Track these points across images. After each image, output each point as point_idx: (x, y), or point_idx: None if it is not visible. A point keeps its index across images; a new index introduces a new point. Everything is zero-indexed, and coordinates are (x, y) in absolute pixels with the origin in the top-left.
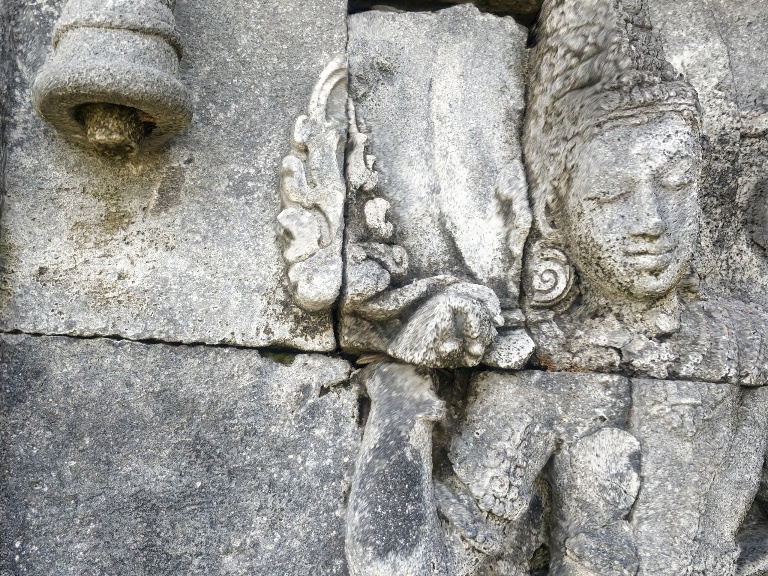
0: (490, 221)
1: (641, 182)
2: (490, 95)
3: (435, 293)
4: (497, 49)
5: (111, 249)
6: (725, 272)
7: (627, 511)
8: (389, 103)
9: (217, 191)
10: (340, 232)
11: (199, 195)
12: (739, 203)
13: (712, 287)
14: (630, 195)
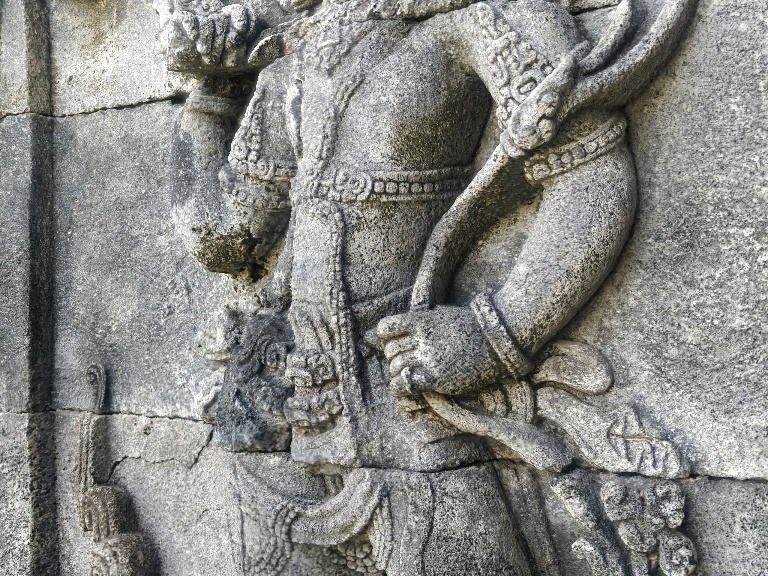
0: None
1: None
2: None
3: None
4: None
5: (99, 57)
6: None
7: (297, 149)
8: None
9: (143, 2)
10: (178, 1)
11: (135, 8)
12: None
13: None
14: None
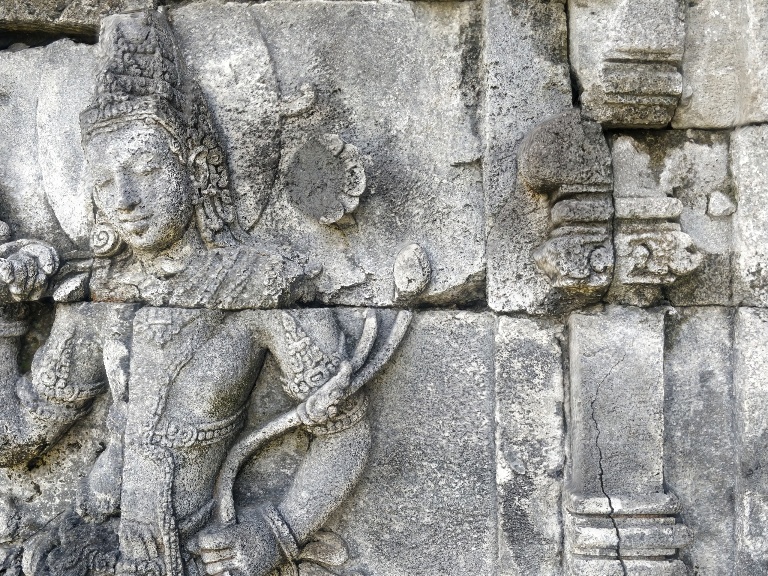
0: (79, 197)
1: (114, 172)
2: (81, 105)
3: (13, 252)
4: (87, 70)
5: None
6: (270, 223)
7: (122, 395)
8: (4, 119)
9: None
10: None
11: None
12: (281, 169)
13: (259, 235)
14: (114, 181)
